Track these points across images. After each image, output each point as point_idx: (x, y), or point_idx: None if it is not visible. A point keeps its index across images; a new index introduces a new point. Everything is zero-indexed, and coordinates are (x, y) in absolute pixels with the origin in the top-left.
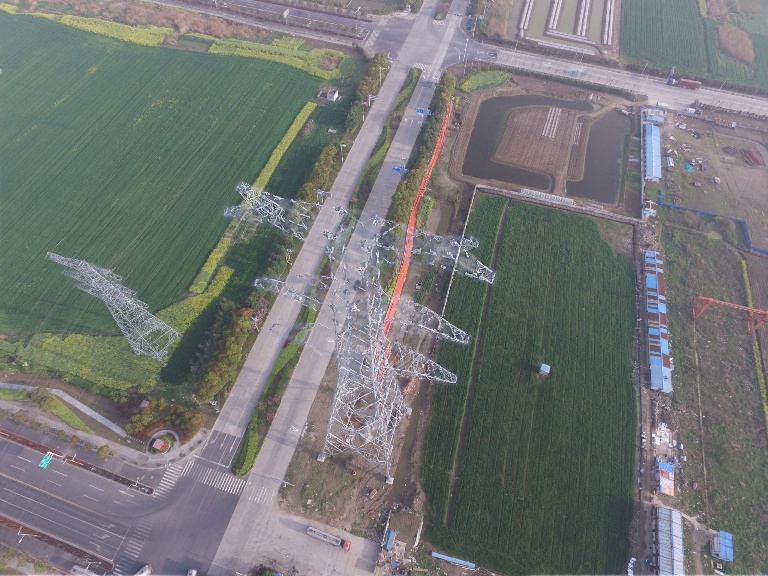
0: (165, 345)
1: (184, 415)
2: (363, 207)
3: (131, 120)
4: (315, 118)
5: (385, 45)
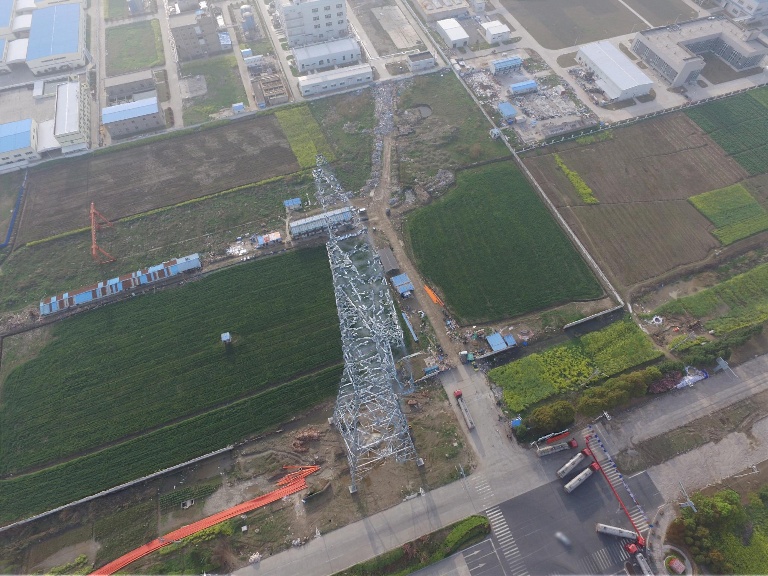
0: None
1: None
2: None
3: None
4: None
5: None
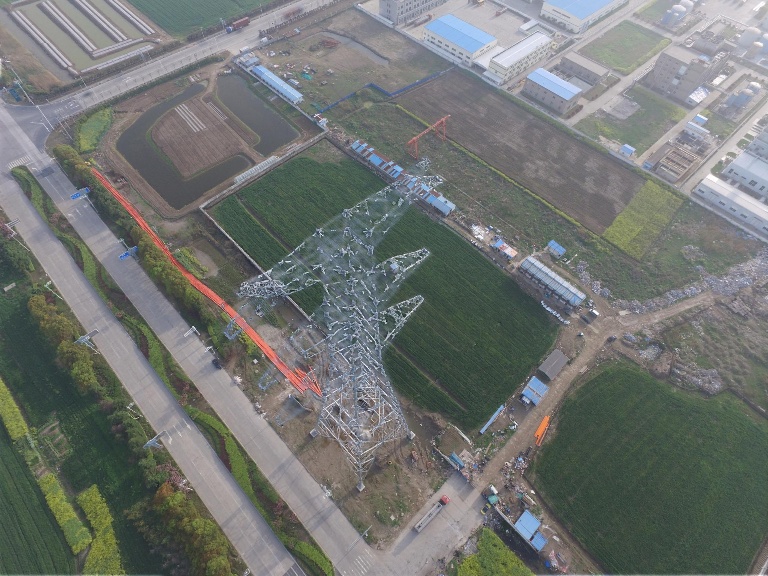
0: None
1: None
2: (136, 311)
3: None
4: None
5: None
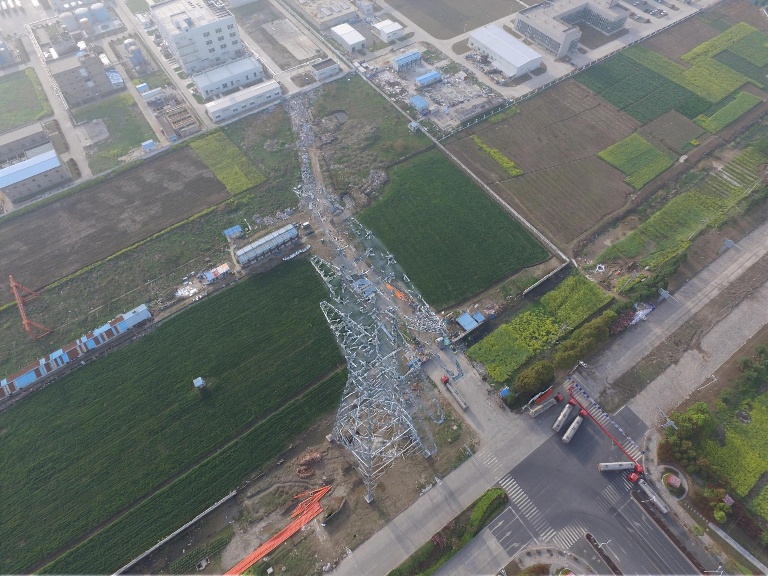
0: None
1: None
2: None
3: None
4: None
5: None
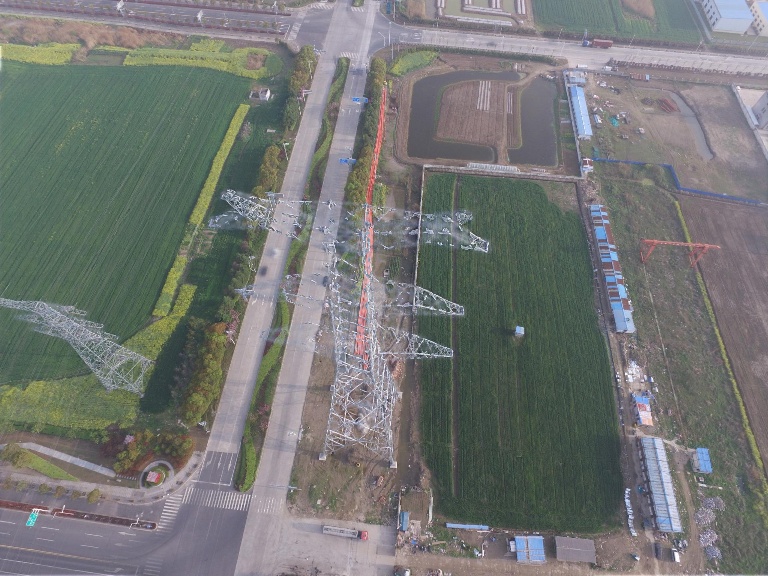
0: (139, 375)
1: (174, 442)
2: (317, 203)
3: (52, 147)
4: (251, 120)
5: (308, 37)
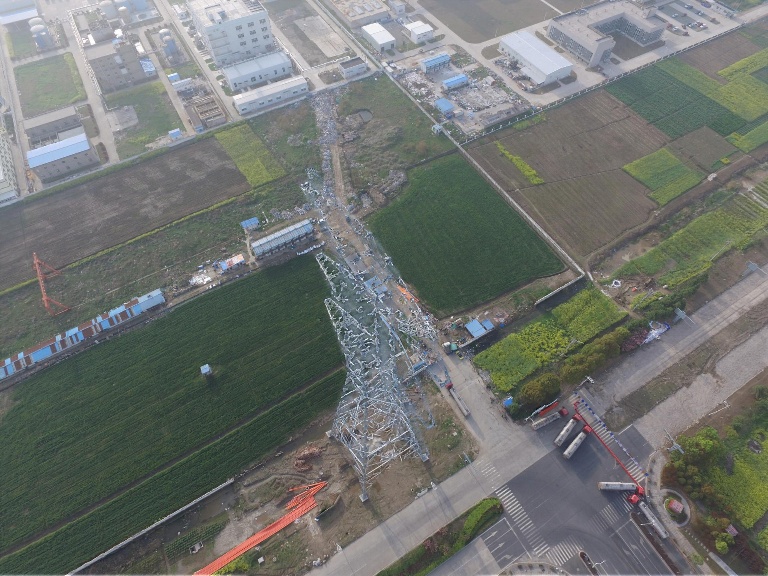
0: None
1: None
2: None
3: None
4: None
5: None
